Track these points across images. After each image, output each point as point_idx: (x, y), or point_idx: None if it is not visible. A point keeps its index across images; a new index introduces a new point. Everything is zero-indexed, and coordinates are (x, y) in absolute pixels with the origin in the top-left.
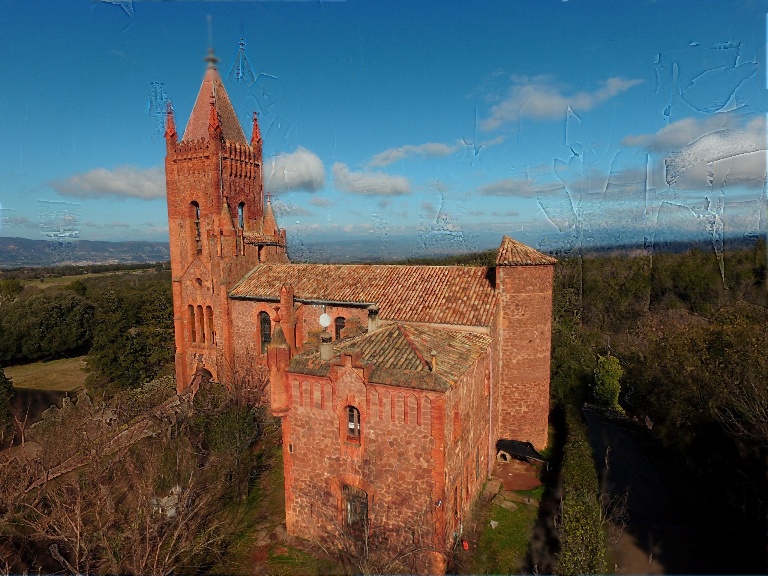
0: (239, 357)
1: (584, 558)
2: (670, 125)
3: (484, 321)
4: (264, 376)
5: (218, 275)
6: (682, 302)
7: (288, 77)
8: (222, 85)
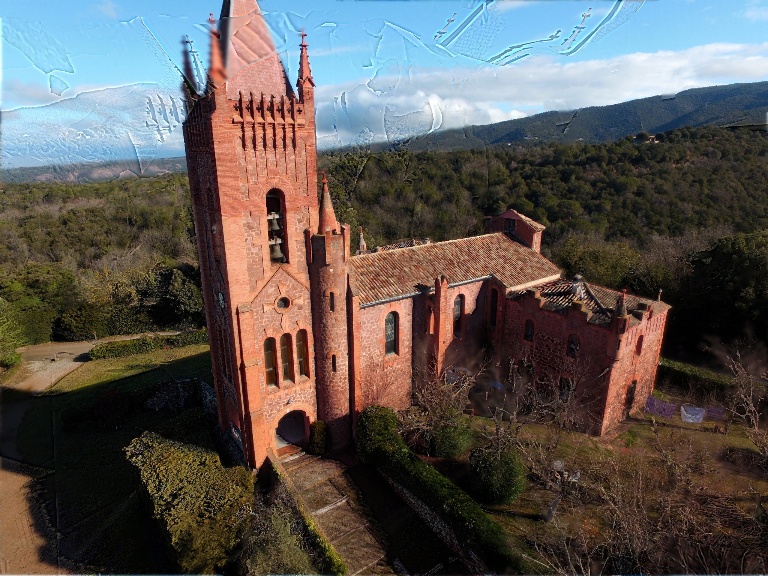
0: (362, 371)
1: (661, 360)
2: (390, 100)
3: (557, 270)
4: (390, 378)
5: (343, 285)
6: (373, 230)
7: (448, 59)
8: None
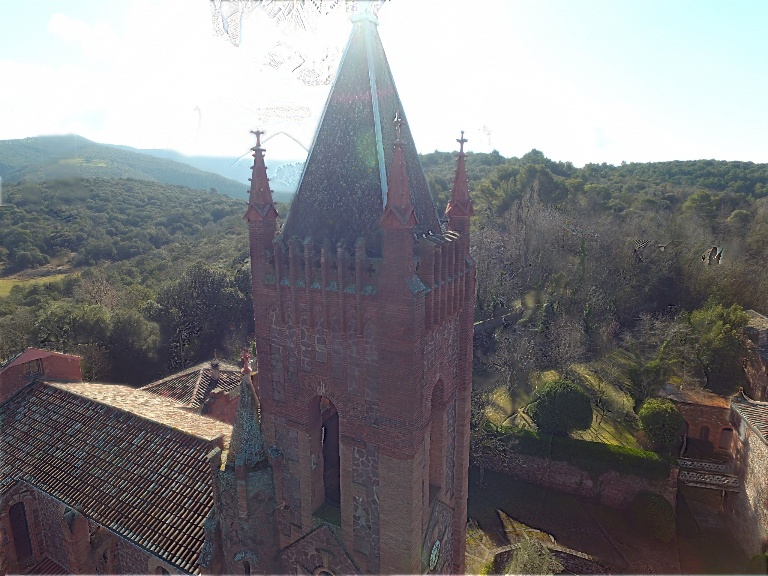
0: None
1: None
2: None
3: None
4: None
5: None
6: None
7: None
8: (342, 66)
